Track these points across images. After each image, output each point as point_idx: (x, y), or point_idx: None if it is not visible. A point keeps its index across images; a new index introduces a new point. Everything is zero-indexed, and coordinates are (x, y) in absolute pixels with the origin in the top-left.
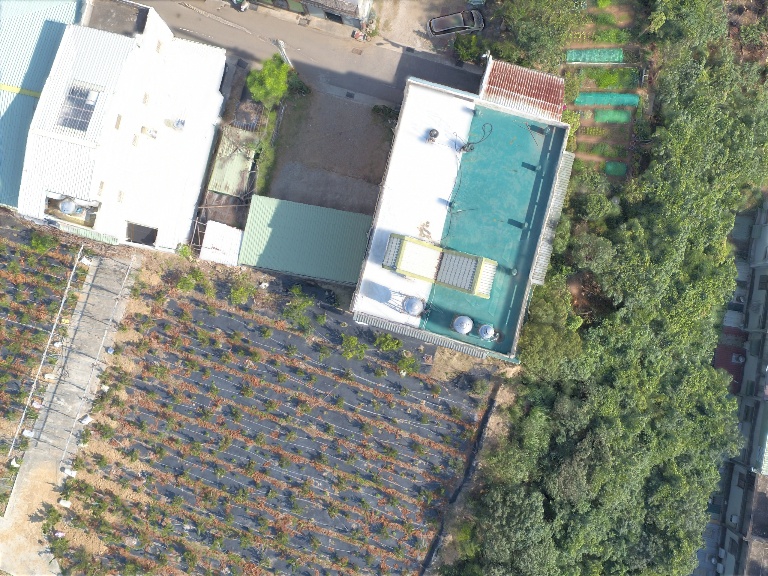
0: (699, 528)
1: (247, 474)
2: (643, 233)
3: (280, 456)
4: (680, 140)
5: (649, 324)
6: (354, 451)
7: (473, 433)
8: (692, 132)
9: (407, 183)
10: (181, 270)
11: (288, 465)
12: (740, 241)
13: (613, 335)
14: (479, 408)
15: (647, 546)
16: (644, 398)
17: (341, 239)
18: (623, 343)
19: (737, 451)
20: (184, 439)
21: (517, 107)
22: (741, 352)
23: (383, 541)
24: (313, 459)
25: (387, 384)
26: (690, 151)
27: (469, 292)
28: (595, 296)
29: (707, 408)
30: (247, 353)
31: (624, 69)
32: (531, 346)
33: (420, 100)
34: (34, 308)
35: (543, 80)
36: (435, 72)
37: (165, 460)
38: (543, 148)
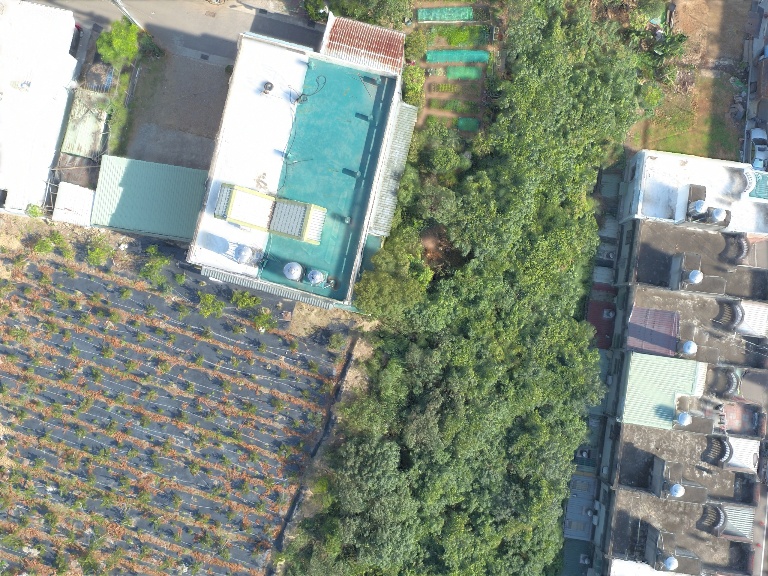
0: (563, 477)
1: None
2: (490, 185)
3: (141, 415)
4: (525, 93)
5: (504, 276)
6: (214, 408)
7: (330, 386)
8: (540, 86)
9: (243, 136)
10: (40, 234)
11: (147, 423)
12: (610, 199)
13: (465, 286)
14: (337, 362)
15: (508, 494)
16: (501, 349)
17: (191, 197)
18: (476, 294)
19: (598, 400)
20: (45, 401)
21: (358, 62)
22: (612, 307)
23: (245, 497)
24: (174, 417)
25: (246, 341)
26: (538, 105)
27: (298, 239)
28: (453, 250)
29: (567, 358)
30: (107, 314)
31: (474, 27)
32: (366, 292)
33: (255, 54)
34: None
35: (384, 35)
36: (288, 33)
37: (27, 423)
38: (376, 99)
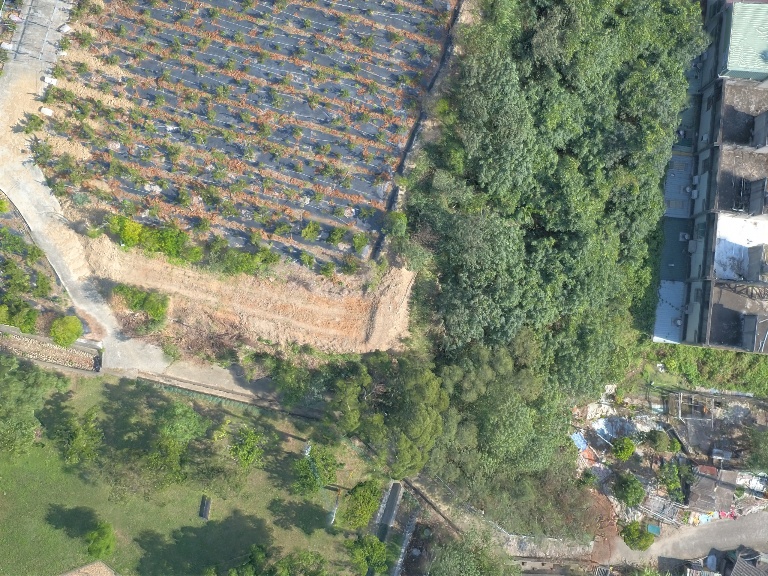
0: None
1: (227, 74)
2: None
3: (258, 54)
4: None
5: None
6: (331, 44)
7: (446, 15)
8: None
9: None
10: None
11: None
12: None
13: None
14: None
15: (621, 129)
16: None
17: None
18: None
19: (703, 47)
20: (163, 43)
21: None
22: None
23: (364, 129)
24: (291, 55)
25: None
26: None
27: None
28: None
29: (672, 6)
30: None
31: None
32: None
33: None
34: None
35: None
36: None
37: (145, 64)
38: None
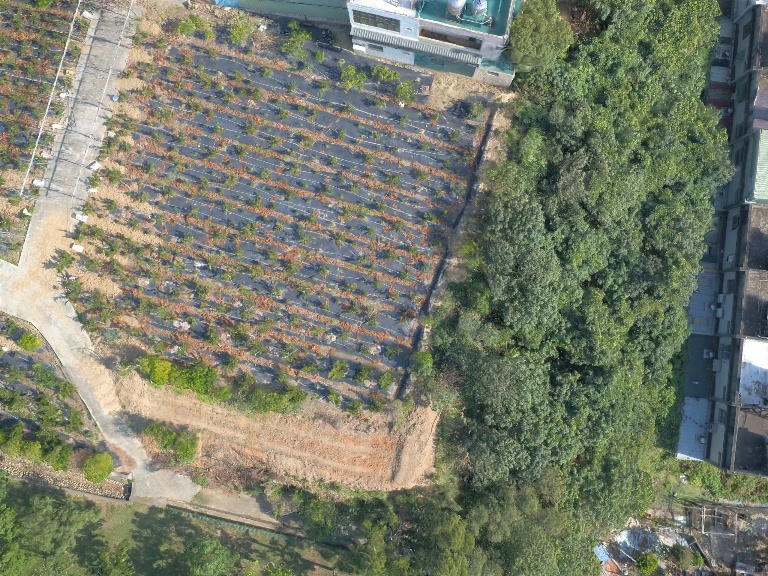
0: (696, 253)
1: (254, 210)
2: None
3: (286, 191)
4: None
5: (638, 48)
6: (358, 181)
7: (472, 154)
8: None
9: None
10: (180, 19)
11: (294, 195)
12: (723, 0)
13: (603, 51)
14: (477, 133)
15: (647, 263)
16: (636, 119)
17: None
18: (613, 62)
19: (729, 176)
20: (191, 180)
21: None
22: (729, 105)
23: (390, 266)
24: (318, 192)
25: (386, 115)
26: None
27: None
28: (584, 28)
29: (698, 135)
30: (249, 93)
31: None
32: (524, 28)
33: None
34: (38, 63)
35: None
36: None
37: (174, 201)
38: None
